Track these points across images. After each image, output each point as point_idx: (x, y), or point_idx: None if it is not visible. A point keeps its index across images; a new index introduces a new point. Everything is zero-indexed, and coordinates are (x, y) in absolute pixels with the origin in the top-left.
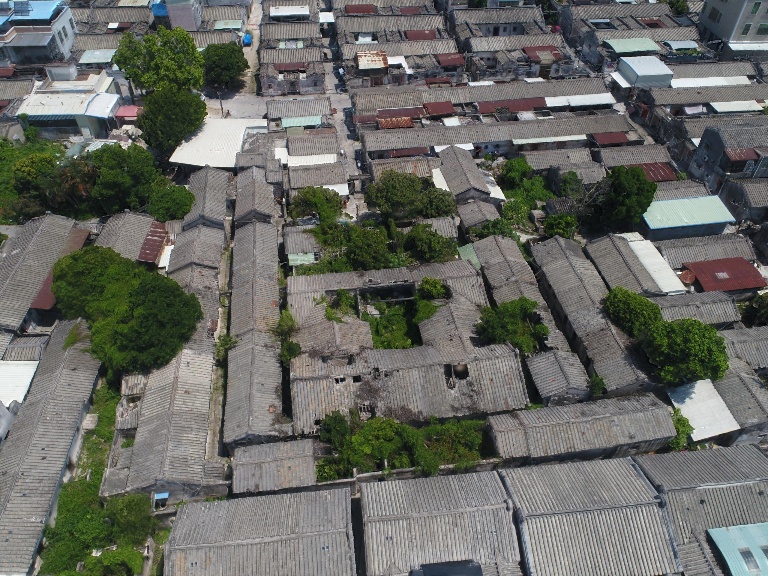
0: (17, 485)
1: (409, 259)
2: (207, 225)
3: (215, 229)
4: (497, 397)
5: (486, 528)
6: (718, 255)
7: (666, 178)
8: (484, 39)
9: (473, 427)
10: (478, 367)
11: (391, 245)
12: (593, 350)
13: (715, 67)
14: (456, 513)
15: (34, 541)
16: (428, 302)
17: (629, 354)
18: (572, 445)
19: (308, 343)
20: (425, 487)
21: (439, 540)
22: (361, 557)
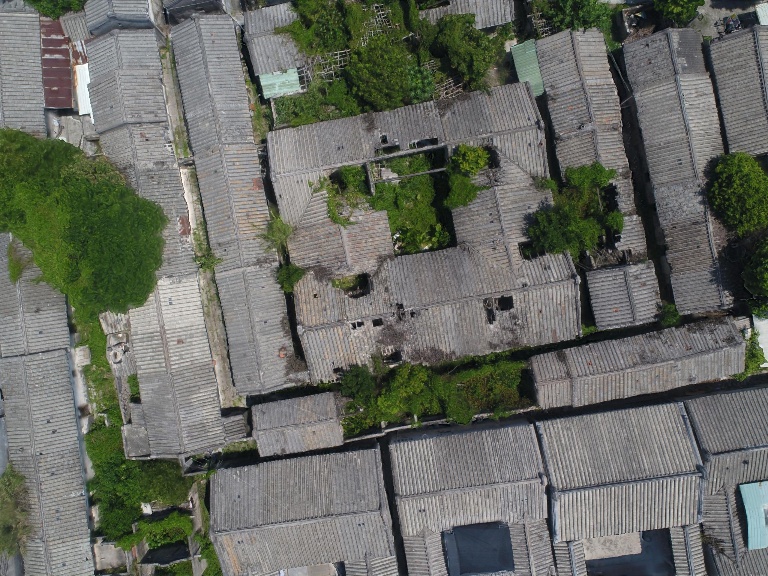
0: (41, 466)
1: (438, 75)
2: (125, 25)
3: (139, 32)
4: (544, 330)
5: (518, 498)
6: None
7: None
8: None
9: (513, 369)
10: (526, 298)
11: (410, 38)
12: (675, 253)
13: None
14: (489, 489)
15: (83, 514)
16: (465, 179)
17: (721, 268)
18: (621, 393)
19: (311, 254)
20: (457, 450)
21: (470, 509)
22: (394, 495)
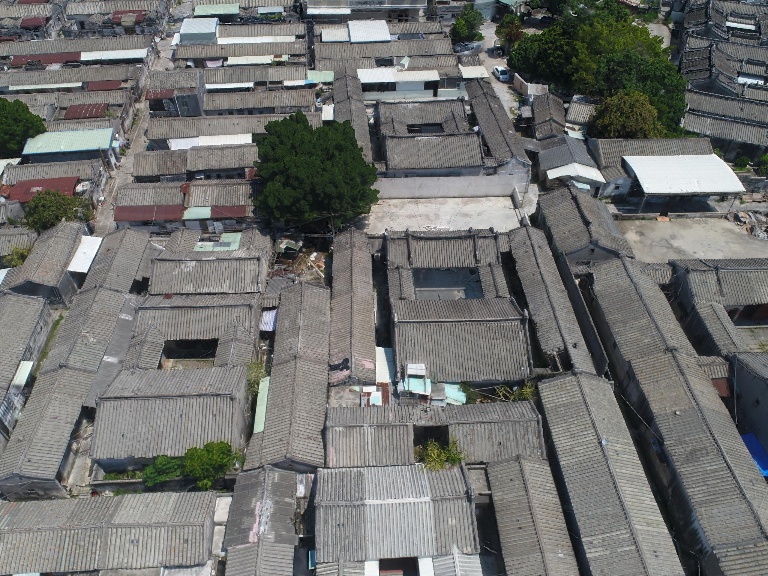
0: None
1: None
2: None
3: None
4: None
5: None
6: (58, 174)
7: (93, 115)
8: (81, 4)
9: None
10: None
11: None
12: None
13: (268, 27)
14: None
15: None
16: None
17: None
18: None
19: None
20: None
21: None
22: None
